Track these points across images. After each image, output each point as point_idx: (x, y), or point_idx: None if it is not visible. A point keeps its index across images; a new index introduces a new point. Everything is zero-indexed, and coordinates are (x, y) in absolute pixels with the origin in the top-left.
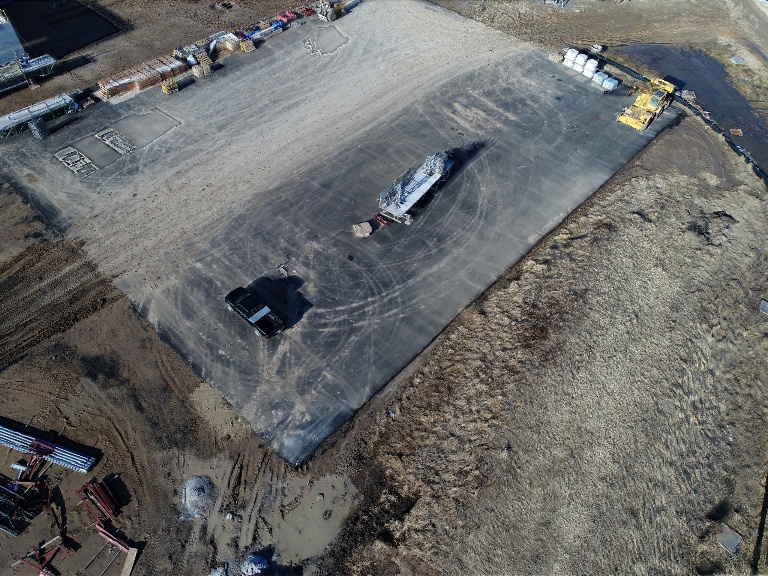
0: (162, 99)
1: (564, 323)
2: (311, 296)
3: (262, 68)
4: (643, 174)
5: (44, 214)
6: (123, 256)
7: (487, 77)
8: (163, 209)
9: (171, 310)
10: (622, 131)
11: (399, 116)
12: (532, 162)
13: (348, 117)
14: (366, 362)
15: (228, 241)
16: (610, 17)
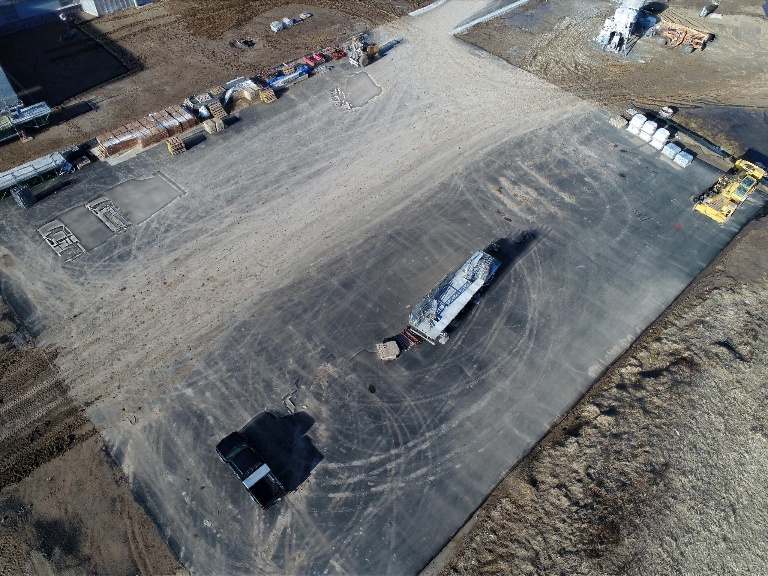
0: (167, 160)
1: (641, 519)
2: (322, 443)
3: (282, 124)
4: (727, 284)
5: (16, 311)
6: (101, 375)
7: (539, 144)
8: (154, 310)
9: (151, 456)
10: (699, 222)
11: (436, 193)
12: (592, 261)
13: (377, 192)
14: (385, 548)
15: (227, 358)
16: (680, 70)
